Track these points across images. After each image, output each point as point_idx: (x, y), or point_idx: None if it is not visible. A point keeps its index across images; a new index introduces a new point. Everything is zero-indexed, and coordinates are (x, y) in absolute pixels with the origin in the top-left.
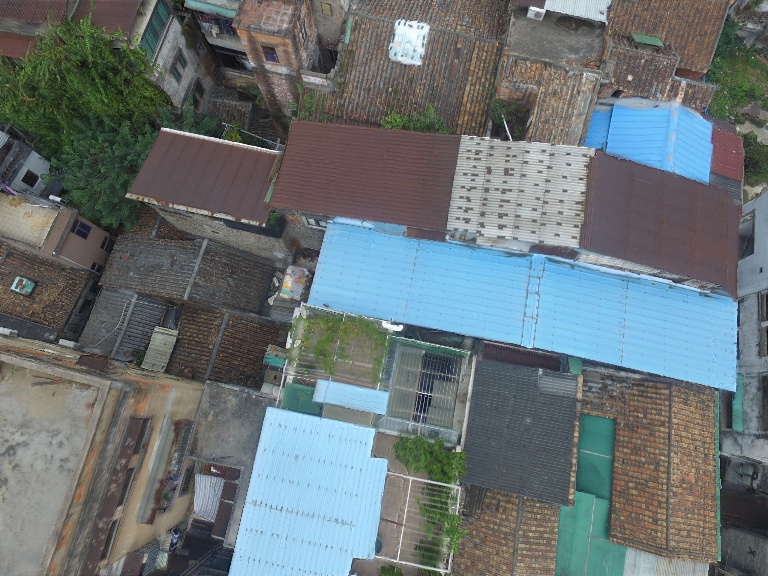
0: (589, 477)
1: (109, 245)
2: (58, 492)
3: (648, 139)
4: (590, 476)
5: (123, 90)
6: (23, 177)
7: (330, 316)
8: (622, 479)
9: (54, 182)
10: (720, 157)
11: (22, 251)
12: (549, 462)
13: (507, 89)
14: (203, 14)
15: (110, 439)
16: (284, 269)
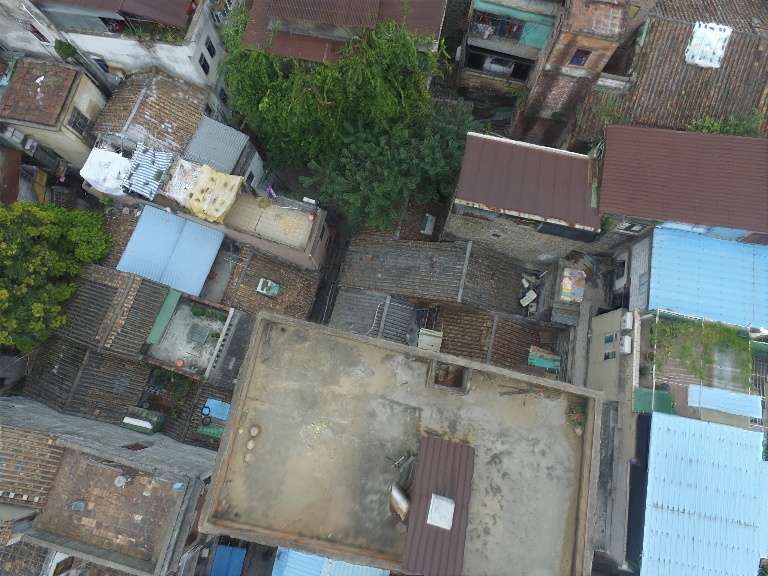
0: None
1: None
2: (553, 499)
3: None
4: None
5: None
6: (247, 178)
7: (689, 321)
8: None
9: (264, 182)
10: None
11: (264, 253)
12: None
13: None
14: (488, 16)
15: None
16: None
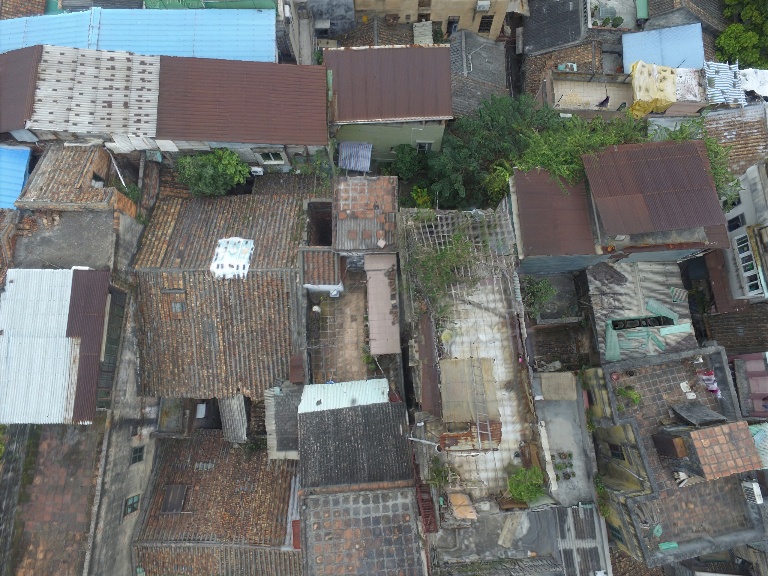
0: None
1: None
2: None
3: None
4: None
5: None
6: None
7: None
8: None
9: None
10: None
11: None
12: None
13: None
14: None
15: None
16: None
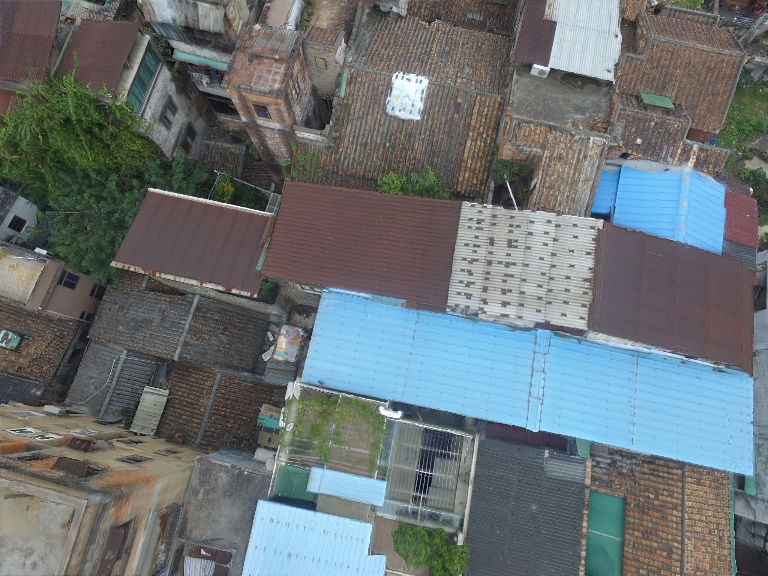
0: (598, 560)
1: (99, 292)
2: None
3: (658, 205)
4: (599, 559)
5: (110, 144)
6: (9, 223)
7: (325, 397)
8: (633, 565)
9: (42, 225)
10: (734, 222)
11: (8, 303)
12: (556, 554)
13: (510, 151)
14: (192, 65)
15: (88, 558)
16: (279, 323)
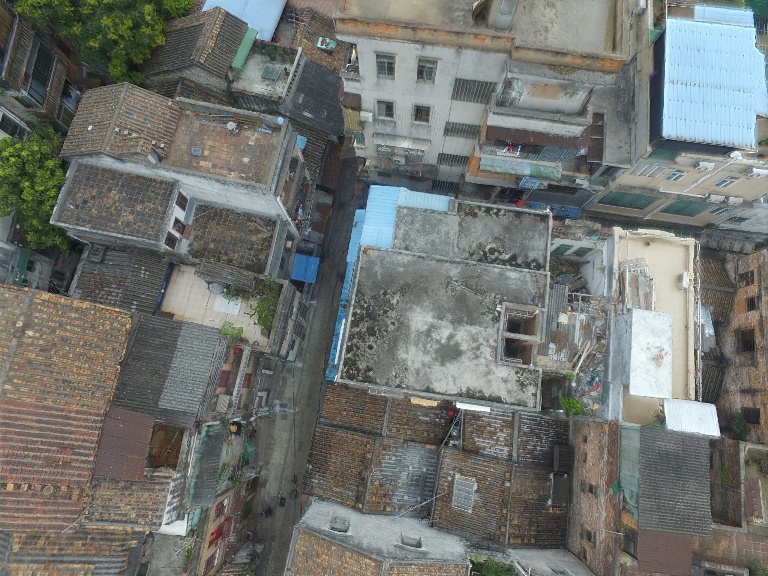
0: None
1: None
2: (596, 11)
3: None
4: None
5: None
6: None
7: None
8: None
9: None
10: None
11: (322, 16)
12: None
13: None
14: None
15: None
16: None
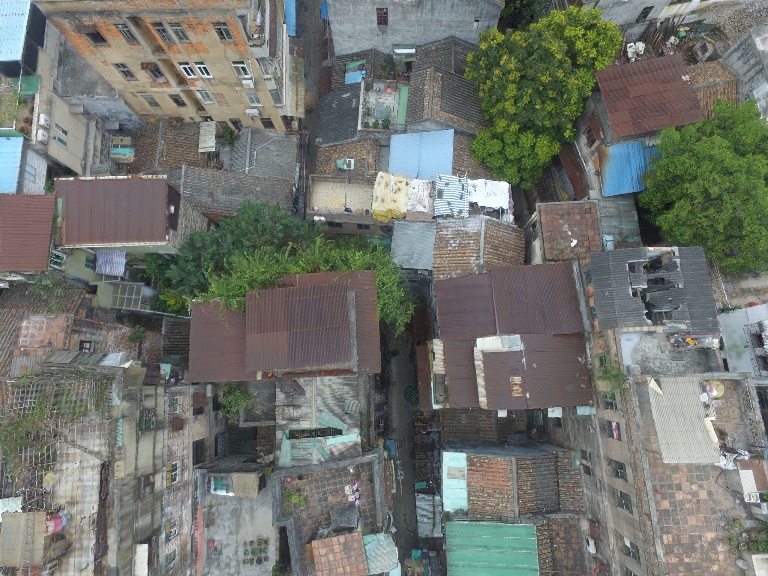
0: None
1: None
2: None
3: None
4: None
5: None
6: None
7: None
8: None
9: None
10: None
11: None
12: None
13: None
14: None
15: None
16: None
